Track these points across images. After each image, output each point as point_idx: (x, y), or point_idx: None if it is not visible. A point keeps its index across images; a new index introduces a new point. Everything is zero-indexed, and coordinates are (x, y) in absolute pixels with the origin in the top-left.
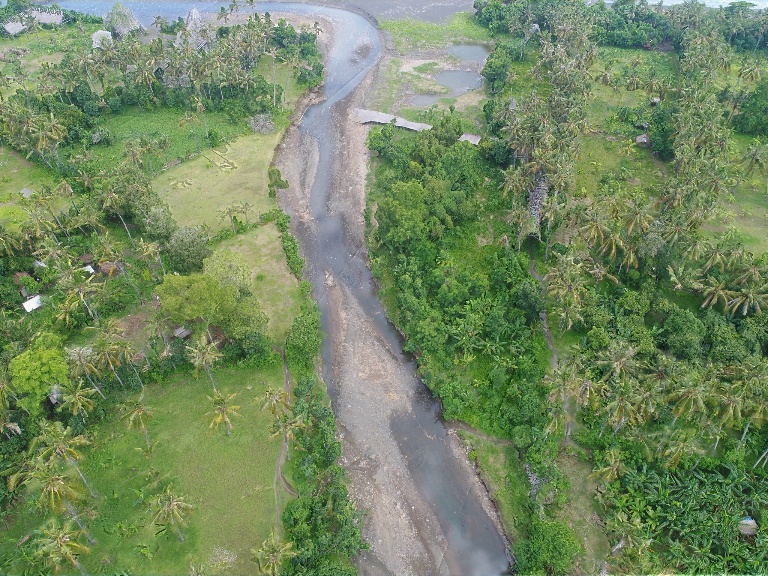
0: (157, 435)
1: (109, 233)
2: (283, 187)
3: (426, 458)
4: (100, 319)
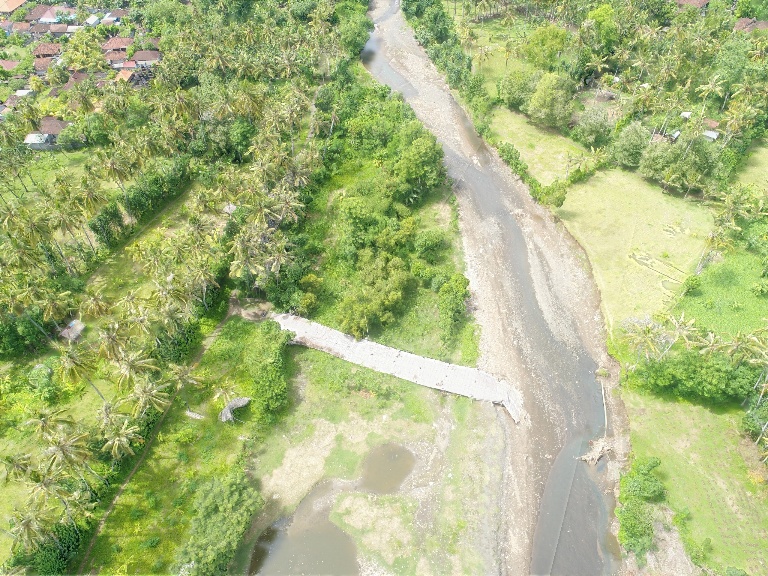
0: None
1: None
2: None
3: (398, 84)
4: None
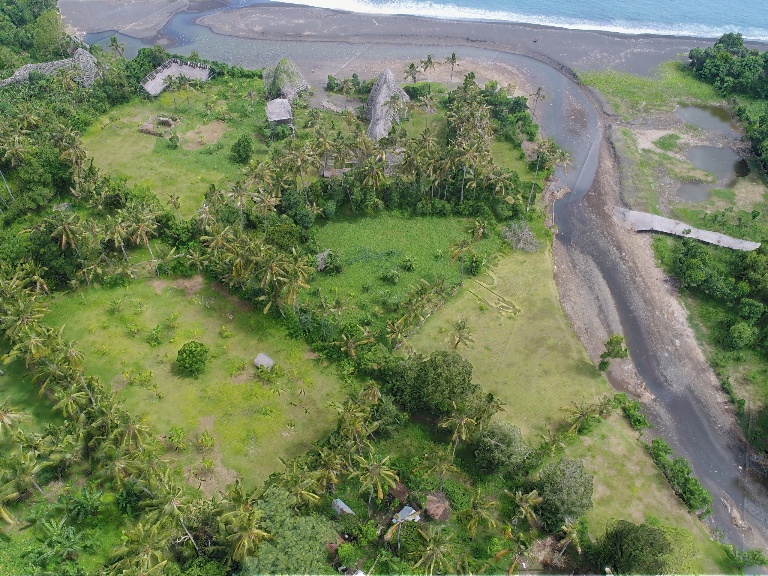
0: None
1: (401, 433)
2: (620, 357)
3: None
4: None
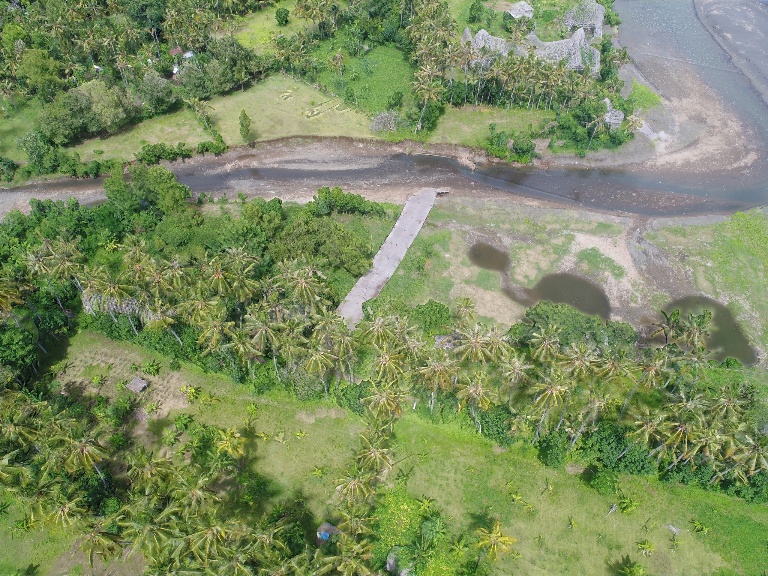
0: (19, 119)
1: None
2: None
3: None
4: (132, 86)
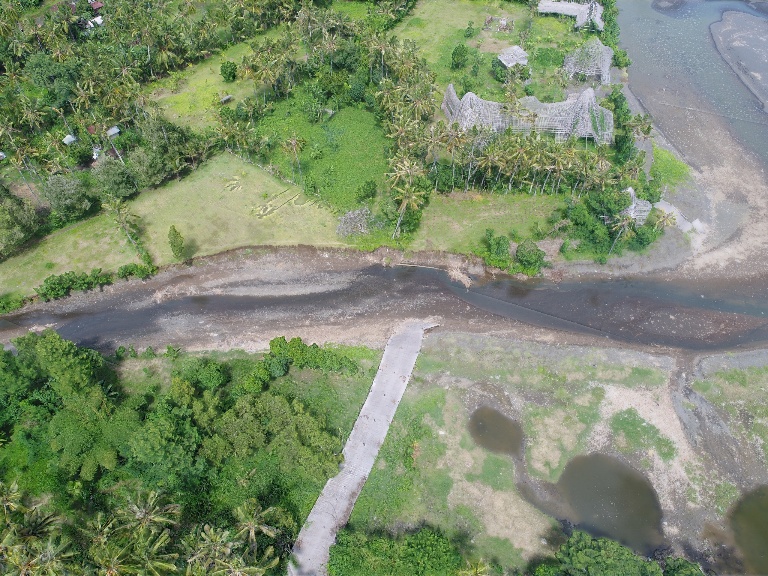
0: None
1: None
2: None
3: None
4: (42, 178)
